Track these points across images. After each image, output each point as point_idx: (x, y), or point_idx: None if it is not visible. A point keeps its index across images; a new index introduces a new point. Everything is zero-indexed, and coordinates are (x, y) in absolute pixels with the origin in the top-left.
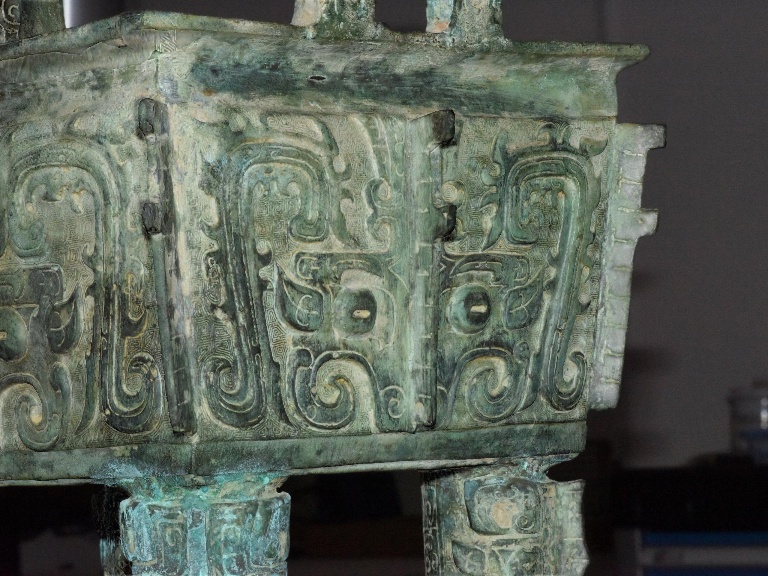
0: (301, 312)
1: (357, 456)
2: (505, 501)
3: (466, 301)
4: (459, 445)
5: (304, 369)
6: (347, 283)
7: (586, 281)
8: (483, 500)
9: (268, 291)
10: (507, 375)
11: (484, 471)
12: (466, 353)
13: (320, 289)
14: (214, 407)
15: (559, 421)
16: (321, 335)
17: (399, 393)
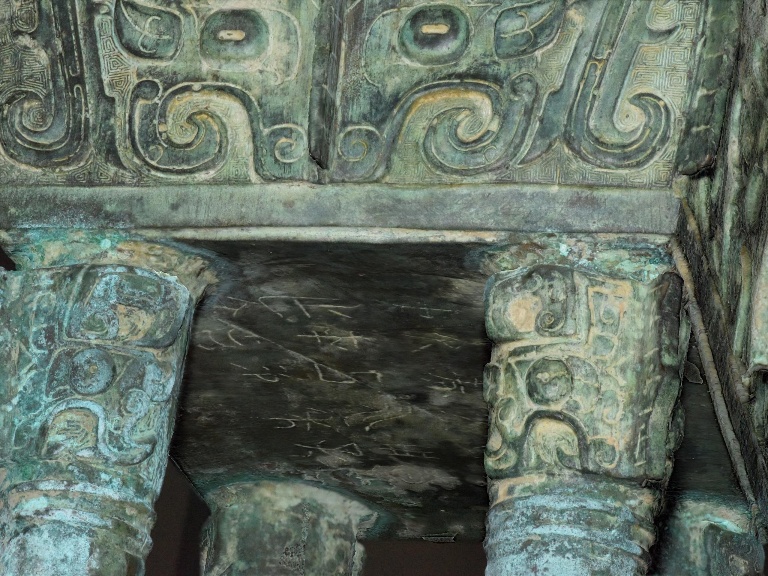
0: (149, 38)
1: (239, 215)
2: (527, 296)
3: (414, 20)
4: (417, 208)
5: (148, 104)
6: (221, 4)
7: (667, 3)
8: (499, 298)
9: (104, 16)
10: (493, 115)
11: (512, 264)
12: (420, 87)
13: (177, 10)
14: (6, 143)
15: (608, 184)
16: (181, 66)
17: (296, 133)
